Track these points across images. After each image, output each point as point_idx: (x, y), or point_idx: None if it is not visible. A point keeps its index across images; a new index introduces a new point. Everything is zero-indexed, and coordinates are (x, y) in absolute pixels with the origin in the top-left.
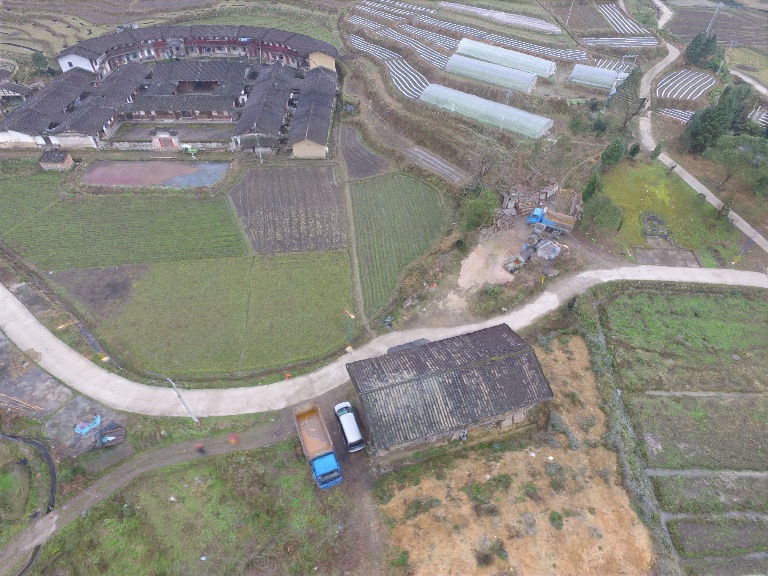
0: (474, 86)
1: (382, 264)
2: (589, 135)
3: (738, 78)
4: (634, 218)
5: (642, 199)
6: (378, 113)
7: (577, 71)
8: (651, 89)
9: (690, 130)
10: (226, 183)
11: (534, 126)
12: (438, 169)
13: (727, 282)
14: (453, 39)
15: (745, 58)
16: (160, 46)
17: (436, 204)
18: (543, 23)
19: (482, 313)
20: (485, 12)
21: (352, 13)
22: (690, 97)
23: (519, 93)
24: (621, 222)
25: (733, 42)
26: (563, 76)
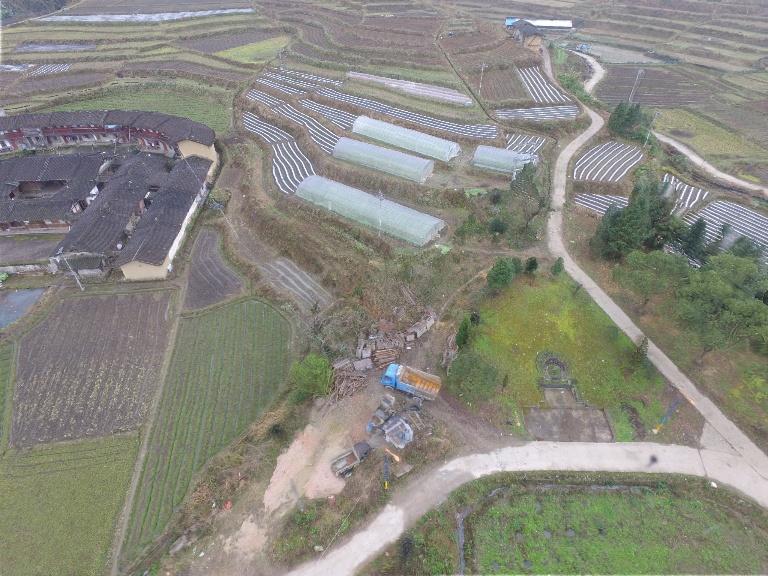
0: (361, 176)
1: (178, 458)
2: (485, 238)
3: (671, 147)
4: (529, 362)
5: (539, 334)
6: (246, 213)
7: (479, 154)
8: (567, 170)
9: (600, 235)
10: (23, 324)
11: (417, 231)
12: (297, 292)
13: (645, 468)
14: (353, 115)
15: (680, 121)
16: (15, 137)
17: (283, 346)
18: (454, 94)
19: (284, 558)
20: (394, 83)
21: (253, 87)
22: (612, 178)
23: (410, 184)
24: (505, 378)
25: (657, 113)
26: (466, 159)
